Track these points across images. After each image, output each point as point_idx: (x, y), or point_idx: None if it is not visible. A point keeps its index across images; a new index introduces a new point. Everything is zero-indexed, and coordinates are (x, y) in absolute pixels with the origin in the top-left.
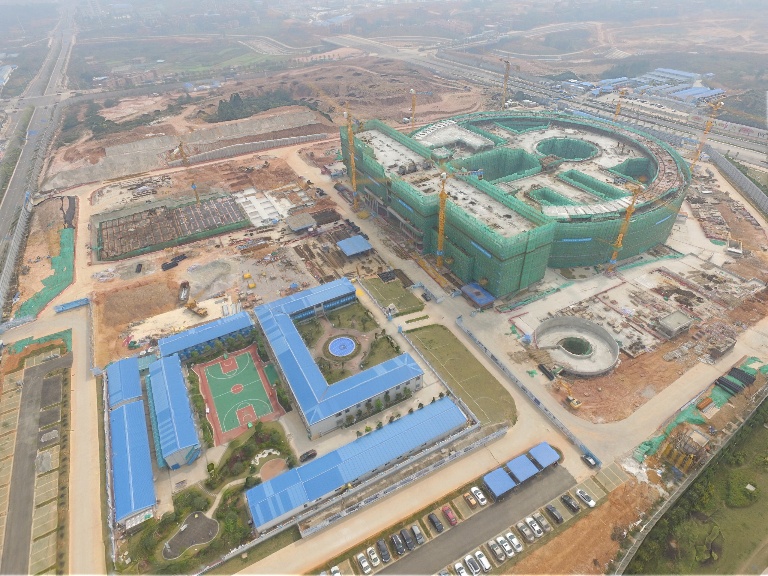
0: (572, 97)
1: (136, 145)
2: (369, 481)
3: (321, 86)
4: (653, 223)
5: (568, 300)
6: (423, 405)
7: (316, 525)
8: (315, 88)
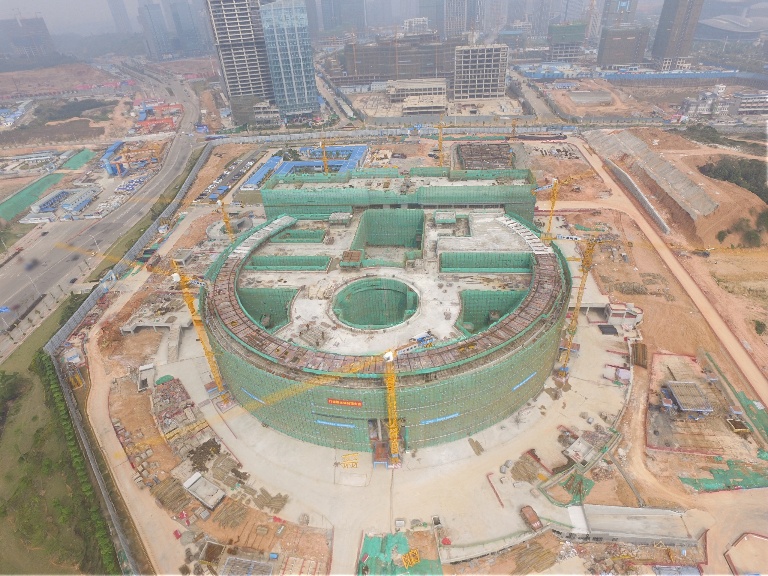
0: None
1: (631, 138)
2: None
3: None
4: None
5: None
6: None
7: None
8: None
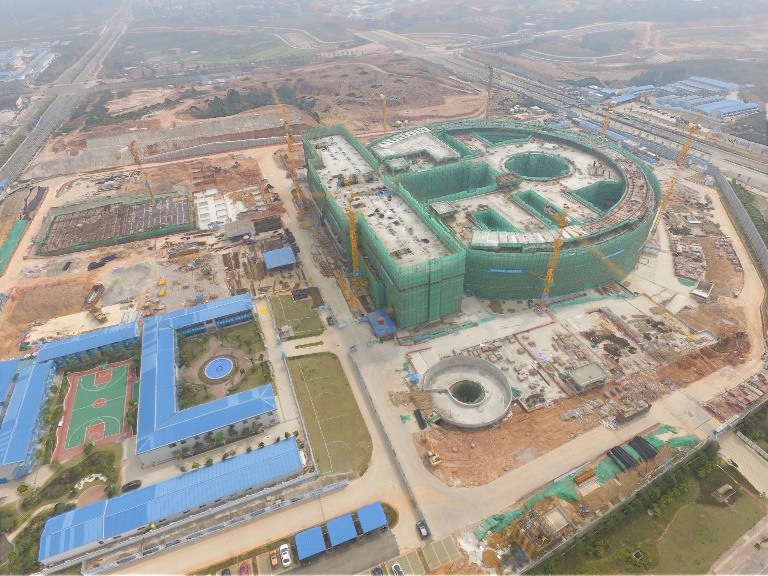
0: None
1: (117, 139)
2: (174, 524)
3: (323, 84)
4: (598, 258)
5: (481, 337)
6: (264, 444)
7: (100, 566)
8: (317, 86)
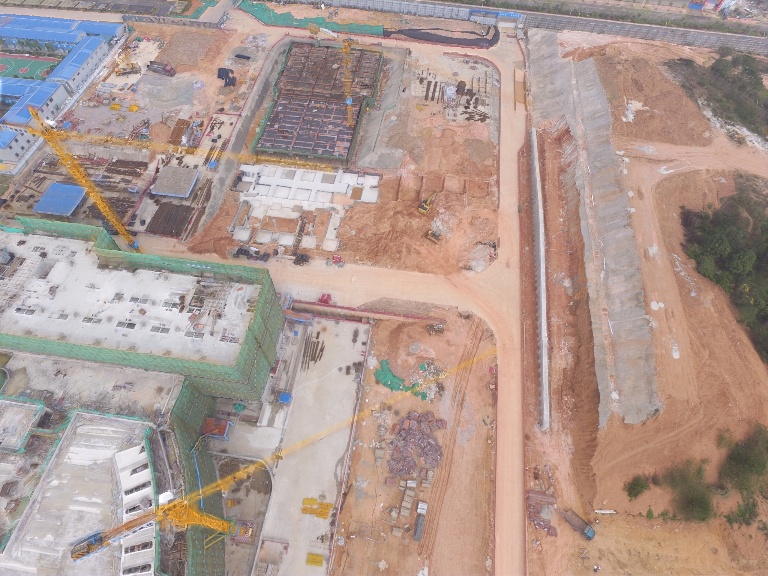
0: None
1: (593, 87)
2: None
3: None
4: None
5: None
6: None
7: None
8: None
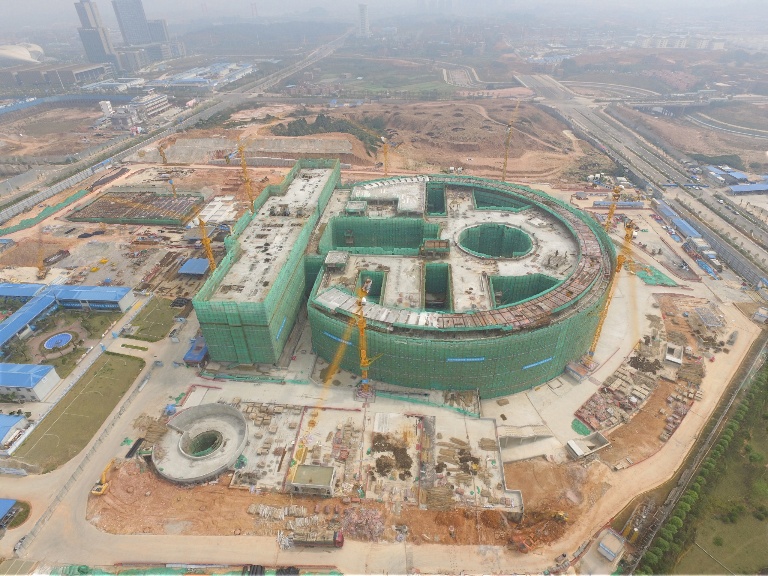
0: (697, 187)
1: (198, 141)
2: None
3: (411, 120)
4: (441, 357)
5: (274, 397)
6: (1, 412)
7: None
8: (405, 121)
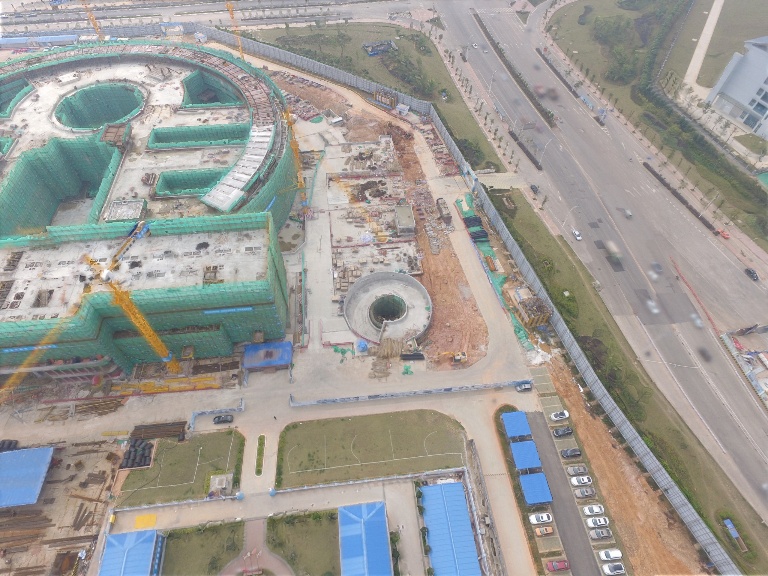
0: None
1: None
2: None
3: None
4: None
5: (324, 272)
6: (424, 527)
7: None
8: None
